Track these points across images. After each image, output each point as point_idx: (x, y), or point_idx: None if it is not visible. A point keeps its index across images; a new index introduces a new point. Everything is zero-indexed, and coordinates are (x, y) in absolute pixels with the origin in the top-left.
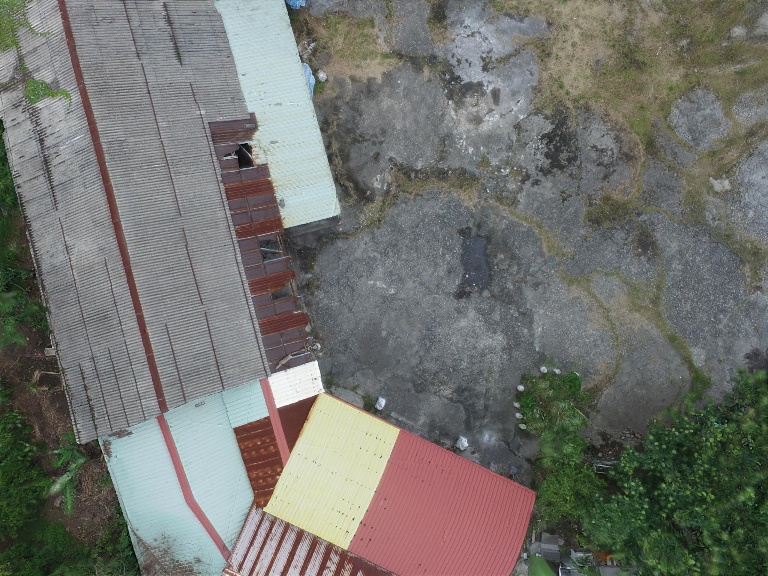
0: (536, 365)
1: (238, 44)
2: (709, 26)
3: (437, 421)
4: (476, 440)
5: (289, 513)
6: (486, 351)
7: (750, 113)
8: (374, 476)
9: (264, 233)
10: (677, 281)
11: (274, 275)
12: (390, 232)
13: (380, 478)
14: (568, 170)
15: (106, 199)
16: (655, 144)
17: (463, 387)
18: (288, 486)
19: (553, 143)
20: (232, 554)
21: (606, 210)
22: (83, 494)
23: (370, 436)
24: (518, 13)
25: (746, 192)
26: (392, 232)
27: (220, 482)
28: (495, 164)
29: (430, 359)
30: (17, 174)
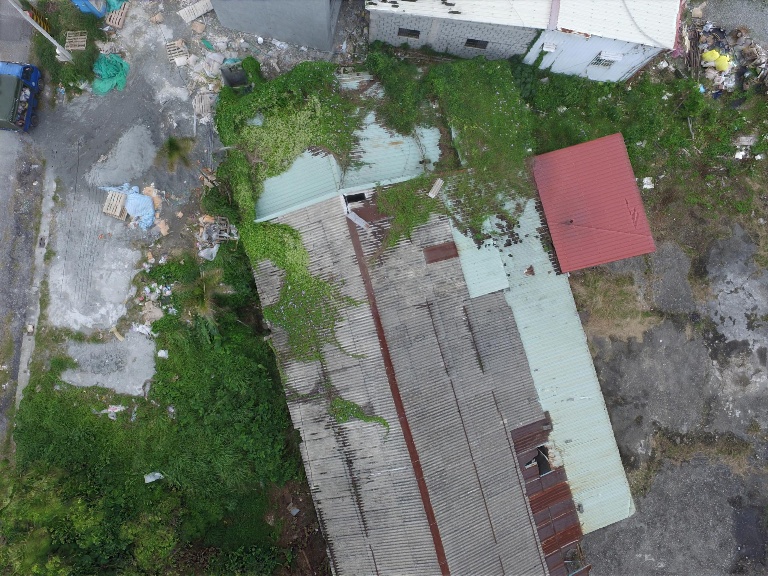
0: None
1: (529, 337)
2: None
3: None
4: None
5: None
6: None
7: None
8: None
9: (566, 543)
10: None
11: None
12: (657, 501)
13: None
14: None
15: (431, 538)
16: None
17: None
18: None
19: None
20: None
21: None
22: None
23: None
24: None
25: None
26: (659, 501)
27: None
28: (764, 428)
29: None
30: (317, 489)
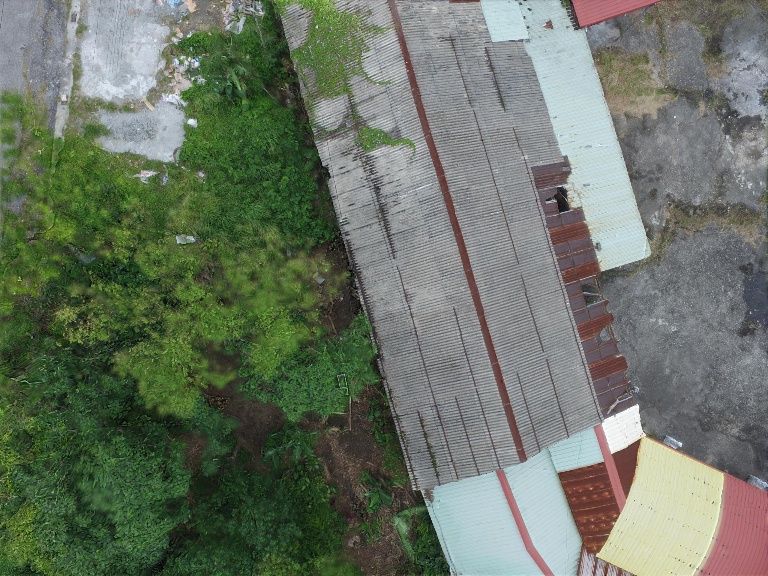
0: None
1: (548, 86)
2: None
3: (726, 460)
4: (766, 479)
5: (622, 559)
6: None
7: None
8: (710, 522)
9: (585, 277)
10: None
11: (597, 319)
12: (671, 269)
13: (716, 524)
14: None
15: (456, 249)
16: None
17: (750, 425)
18: (623, 532)
19: None
20: None
21: None
22: None
23: (698, 481)
24: None
25: None
26: (673, 269)
27: (552, 528)
28: None
29: (716, 397)
30: (345, 222)
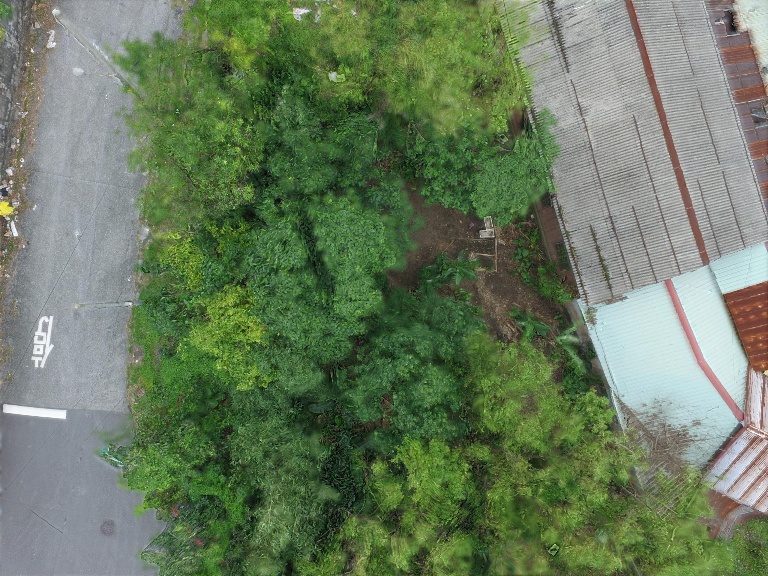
0: None
1: None
2: None
3: None
4: None
5: None
6: None
7: None
8: None
9: (752, 100)
10: None
11: (764, 141)
12: None
13: None
14: None
15: (638, 55)
16: None
17: None
18: None
19: None
20: (748, 413)
21: None
22: (524, 372)
23: None
24: None
25: None
26: None
27: (719, 345)
28: None
29: None
30: (514, 40)
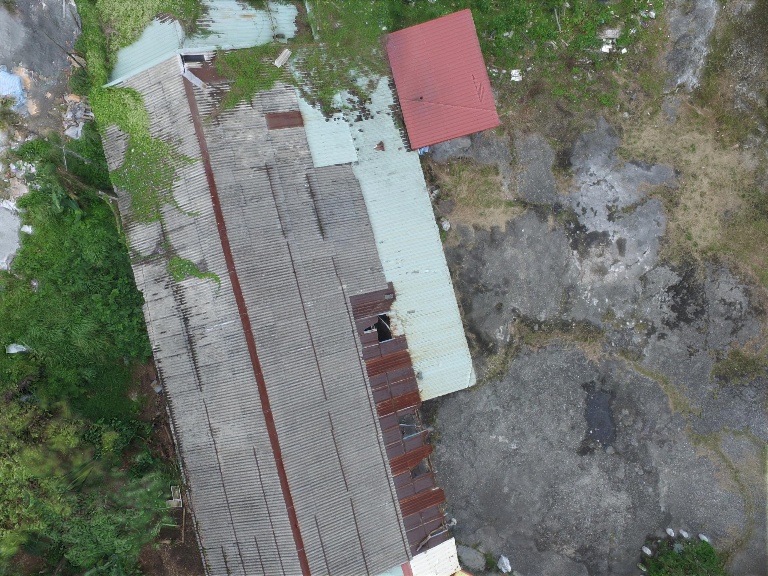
0: (661, 525)
1: (375, 211)
2: None
3: None
4: None
5: None
6: (610, 510)
7: None
8: None
9: (403, 408)
10: None
11: (413, 452)
12: (513, 385)
13: None
14: (695, 324)
15: (256, 388)
16: None
17: (586, 546)
18: None
19: (680, 296)
20: None
21: (734, 366)
22: None
23: None
24: (645, 161)
25: None
26: (515, 385)
27: None
28: (620, 317)
29: (553, 517)
30: (158, 349)
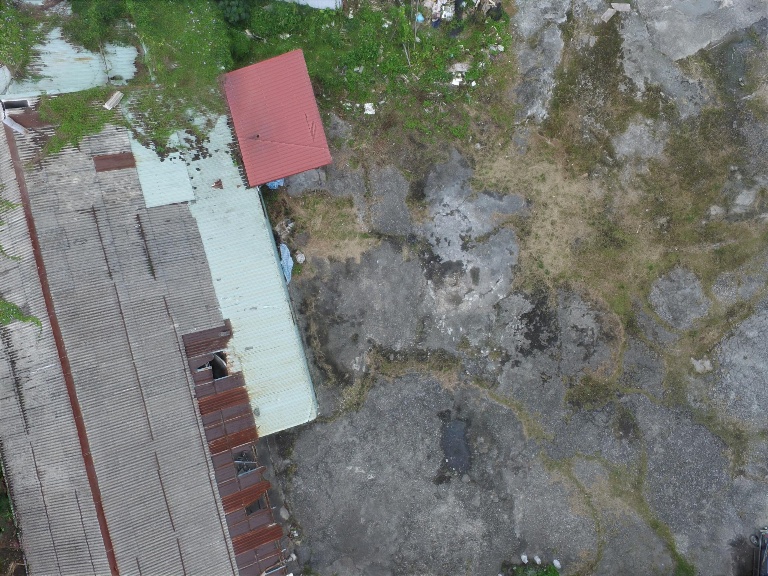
0: (517, 552)
1: (213, 248)
2: (689, 204)
3: None
4: None
5: None
6: (466, 538)
7: (731, 292)
8: None
9: (238, 445)
10: (659, 465)
11: (248, 488)
12: (369, 416)
13: None
14: (548, 351)
15: (76, 431)
16: (636, 324)
17: (443, 575)
18: None
19: (533, 323)
20: None
21: (587, 392)
22: None
23: None
24: (497, 191)
25: (728, 373)
26: (371, 416)
27: None
28: (475, 345)
29: (410, 546)
30: None
